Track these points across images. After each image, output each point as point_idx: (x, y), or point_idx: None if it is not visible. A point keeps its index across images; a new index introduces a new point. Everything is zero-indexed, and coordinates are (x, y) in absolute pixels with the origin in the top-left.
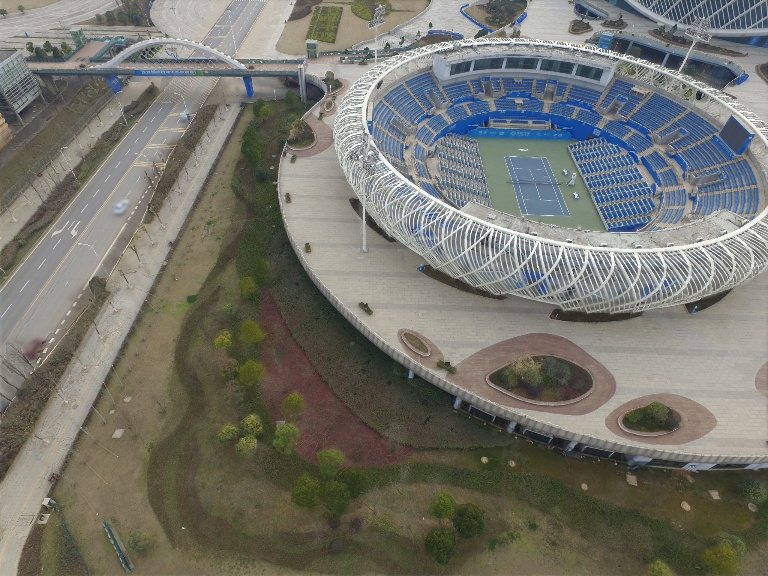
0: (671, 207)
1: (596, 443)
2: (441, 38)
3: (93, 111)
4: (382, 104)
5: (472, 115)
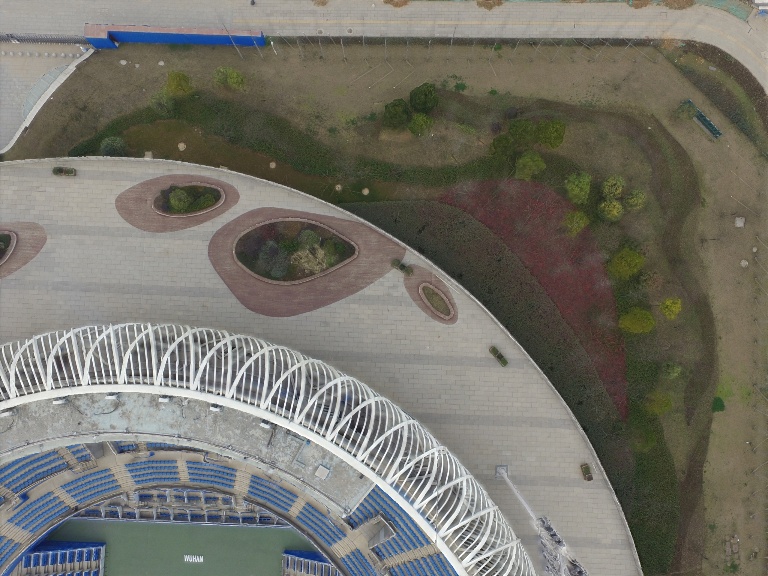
0: None
1: None
2: None
3: None
4: None
5: None
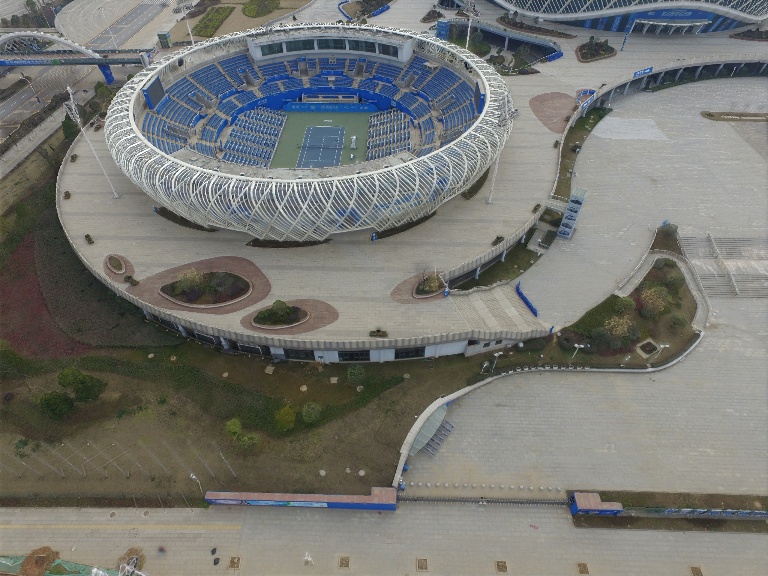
0: None
1: (224, 334)
2: None
3: None
4: (186, 80)
5: (283, 91)
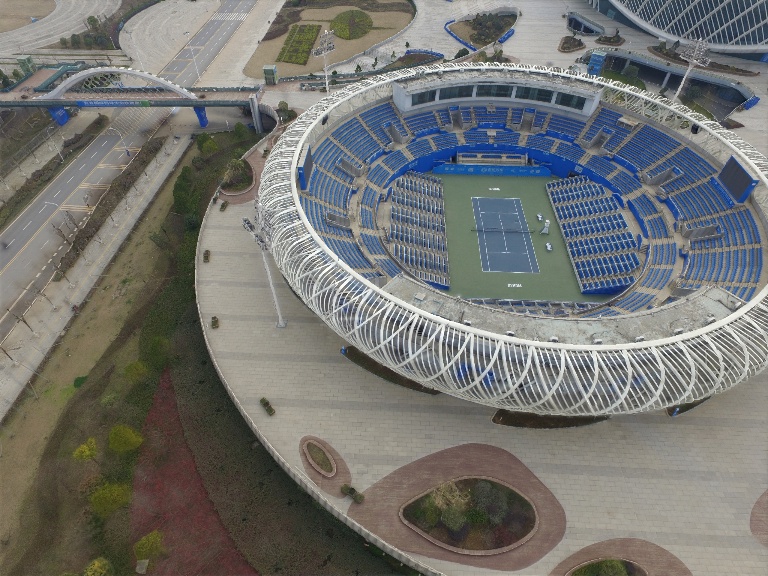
0: (658, 266)
1: None
2: (419, 58)
3: (31, 146)
4: (329, 142)
5: (437, 150)
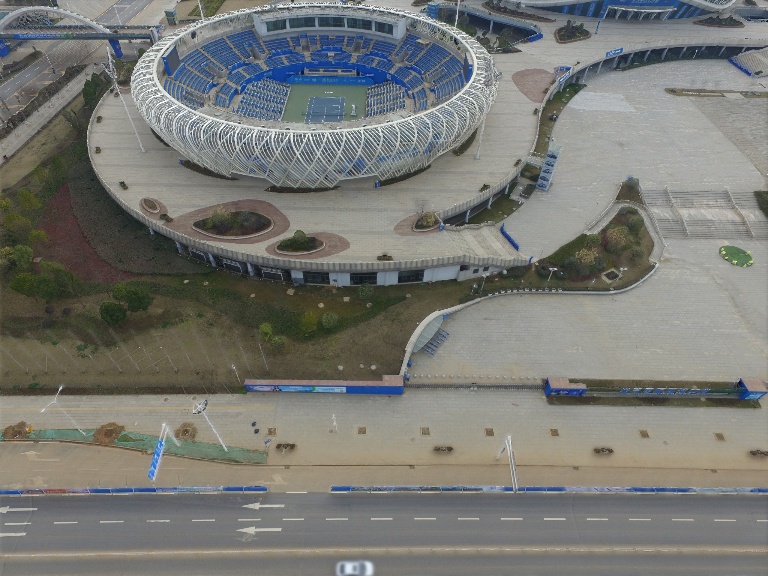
0: None
1: (252, 259)
2: None
3: None
4: (198, 52)
5: (287, 65)
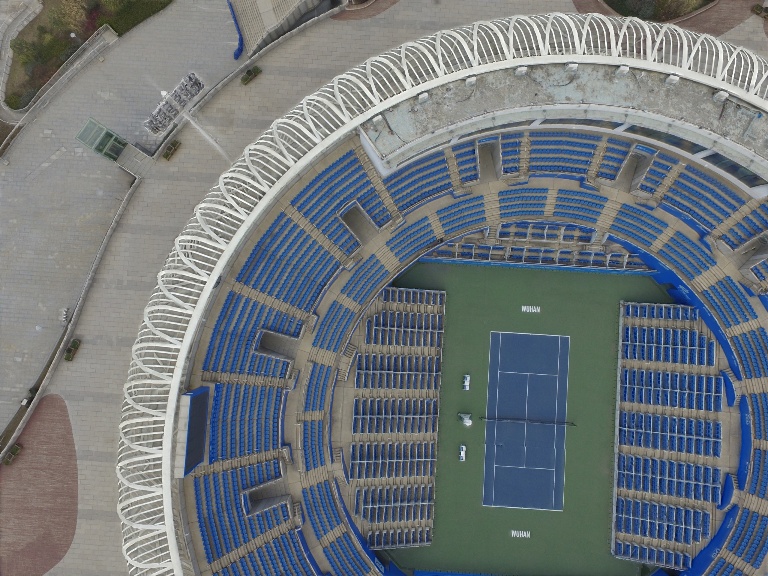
0: (352, 307)
1: None
2: None
3: None
4: None
5: None
